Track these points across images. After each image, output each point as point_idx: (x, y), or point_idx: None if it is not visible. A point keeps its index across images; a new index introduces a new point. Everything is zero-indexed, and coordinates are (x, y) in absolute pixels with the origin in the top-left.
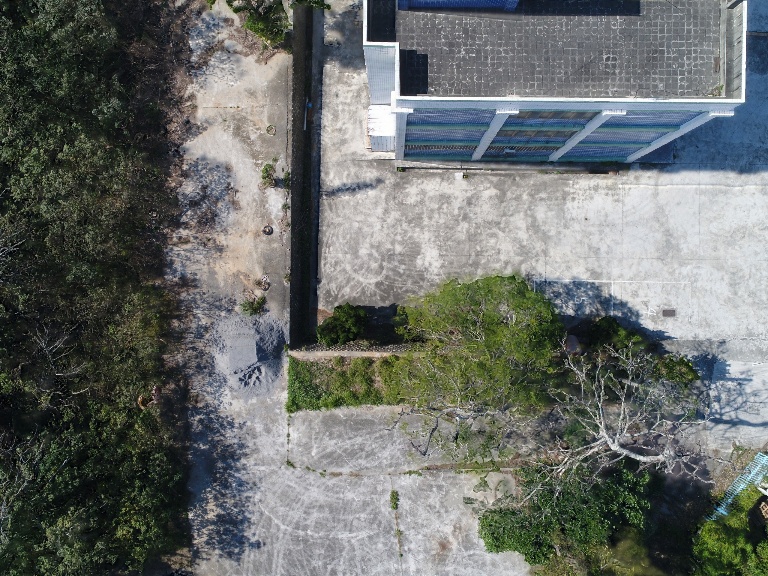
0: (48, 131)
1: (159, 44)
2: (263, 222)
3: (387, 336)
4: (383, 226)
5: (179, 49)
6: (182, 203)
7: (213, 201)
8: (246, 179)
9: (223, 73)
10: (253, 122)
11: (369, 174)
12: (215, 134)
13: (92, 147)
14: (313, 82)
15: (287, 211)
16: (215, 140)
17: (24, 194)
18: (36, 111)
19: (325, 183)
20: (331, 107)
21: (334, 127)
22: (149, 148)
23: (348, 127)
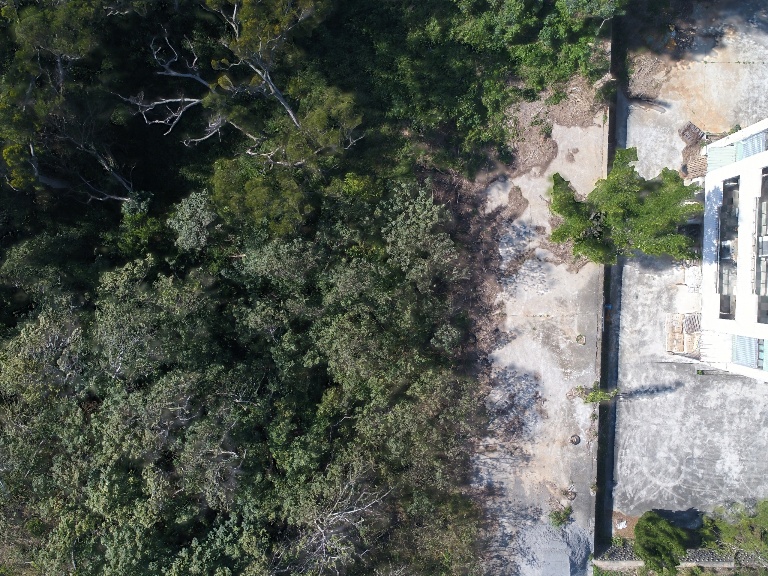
0: (398, 369)
1: (471, 253)
2: (570, 431)
3: (685, 541)
4: (682, 430)
5: (489, 256)
6: (489, 411)
7: (521, 410)
8: (554, 388)
9: (533, 281)
10: (563, 331)
11: (668, 377)
12: (524, 342)
13: (442, 385)
14: (612, 282)
15: (595, 420)
16: (524, 348)
17: (373, 431)
18: (386, 348)
19: (623, 385)
20: (630, 308)
21: (633, 328)
22: (463, 360)
23: (648, 329)
